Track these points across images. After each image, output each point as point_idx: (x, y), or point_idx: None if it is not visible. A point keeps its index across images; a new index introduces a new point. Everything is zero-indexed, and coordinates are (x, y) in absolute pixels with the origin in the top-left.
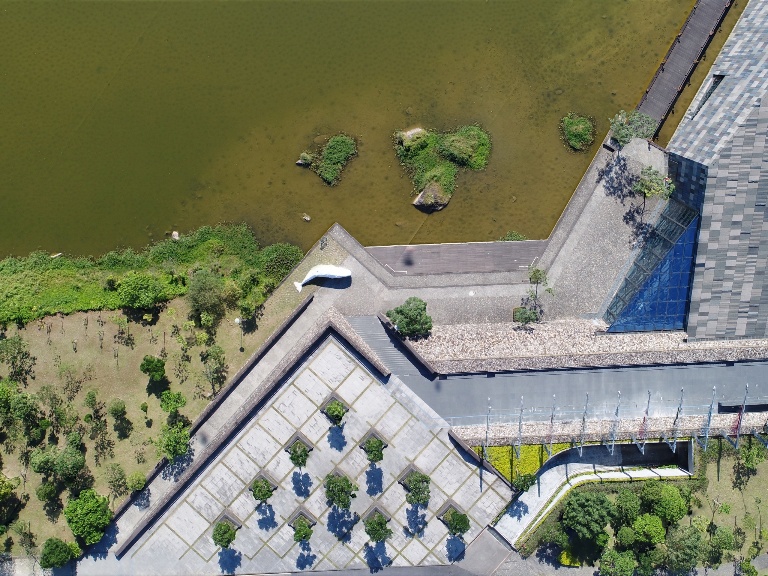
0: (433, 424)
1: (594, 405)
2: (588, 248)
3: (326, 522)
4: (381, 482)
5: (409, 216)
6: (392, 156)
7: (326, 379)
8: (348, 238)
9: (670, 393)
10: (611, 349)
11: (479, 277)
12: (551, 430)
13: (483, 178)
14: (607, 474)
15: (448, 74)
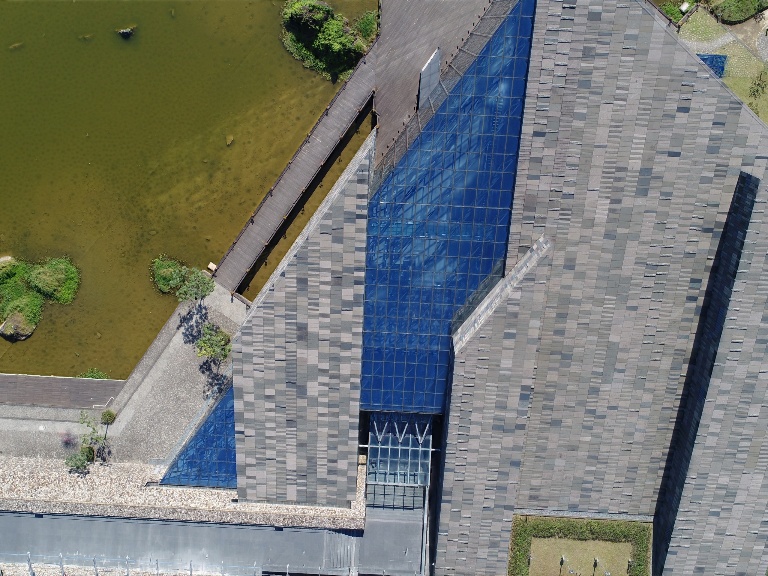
0: None
1: (139, 555)
2: (162, 394)
3: None
4: None
5: None
6: None
7: None
8: None
9: (216, 551)
10: (157, 503)
11: (52, 412)
12: None
13: (69, 312)
14: None
15: (43, 204)
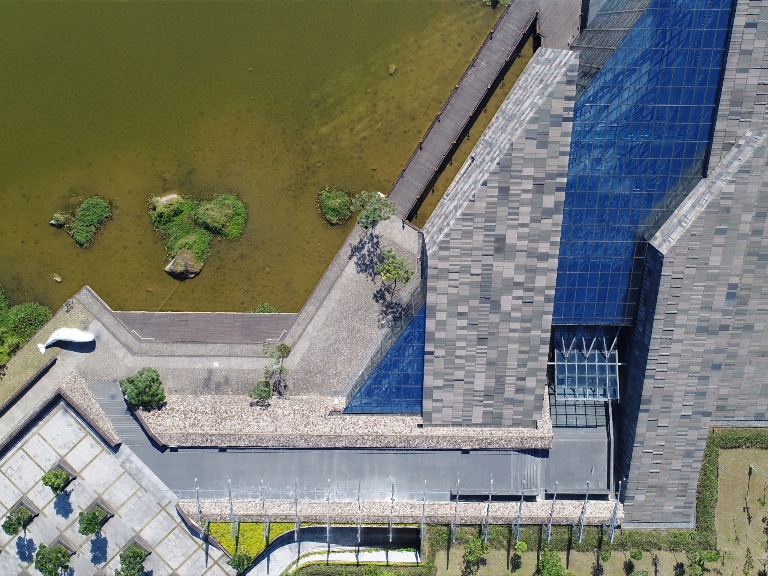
0: (161, 496)
1: (325, 486)
2: (336, 325)
3: None
4: (106, 552)
5: (161, 282)
6: (147, 221)
7: (55, 445)
8: (95, 302)
9: (403, 478)
10: (343, 431)
11: (225, 348)
12: (278, 509)
13: (237, 248)
14: (339, 555)
15: (207, 141)
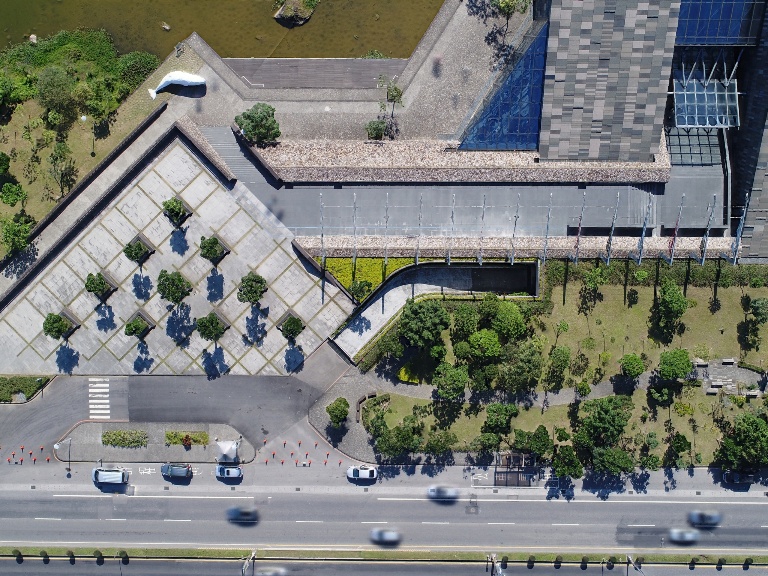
0: (277, 233)
1: (441, 222)
2: (448, 68)
3: (165, 326)
4: (222, 289)
5: (270, 30)
6: None
7: (171, 182)
8: (205, 47)
9: (519, 213)
10: (460, 164)
11: (336, 93)
12: (395, 243)
13: None
14: (453, 295)
15: None
